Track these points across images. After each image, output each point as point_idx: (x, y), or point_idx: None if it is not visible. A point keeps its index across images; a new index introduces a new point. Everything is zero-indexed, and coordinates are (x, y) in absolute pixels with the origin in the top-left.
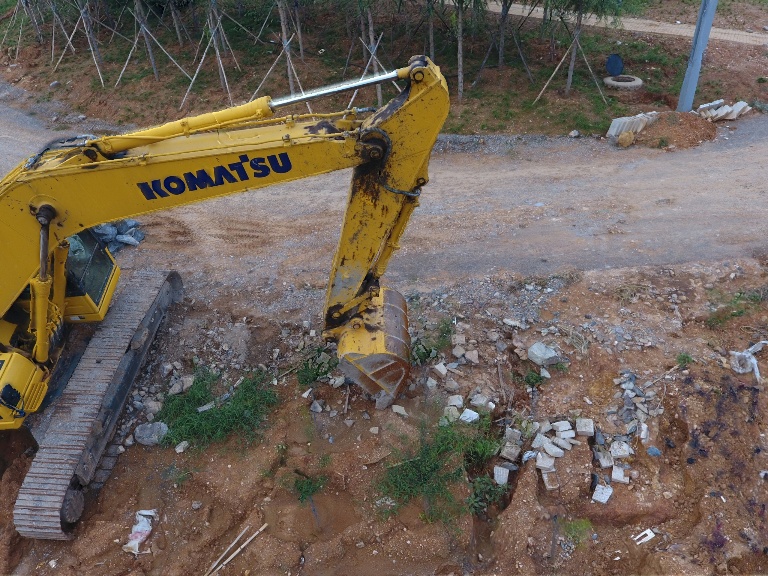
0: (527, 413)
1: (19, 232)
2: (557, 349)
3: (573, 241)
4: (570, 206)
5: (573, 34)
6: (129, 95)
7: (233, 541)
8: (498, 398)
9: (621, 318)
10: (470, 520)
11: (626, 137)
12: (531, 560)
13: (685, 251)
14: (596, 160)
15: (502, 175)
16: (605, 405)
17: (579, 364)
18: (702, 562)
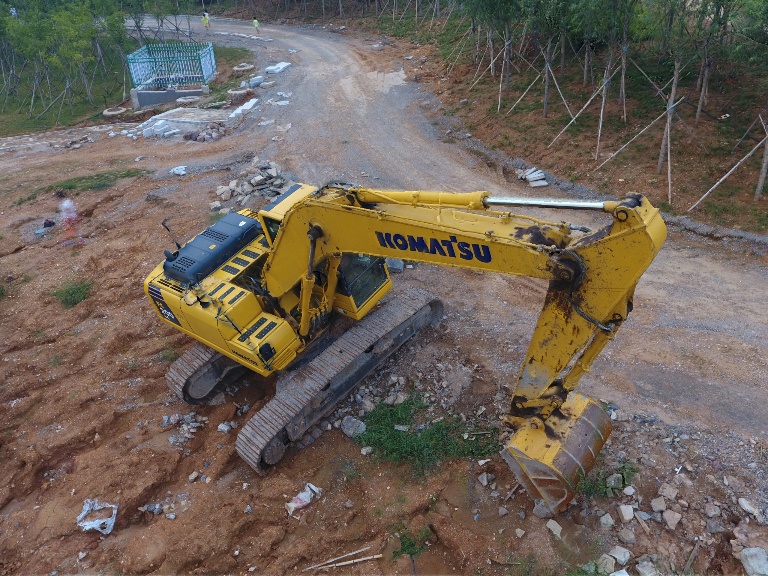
0: None
1: (302, 238)
2: None
3: None
4: None
5: None
6: (514, 124)
7: (354, 551)
8: None
9: None
10: None
11: None
12: None
13: None
14: None
15: None
16: None
17: None
18: None
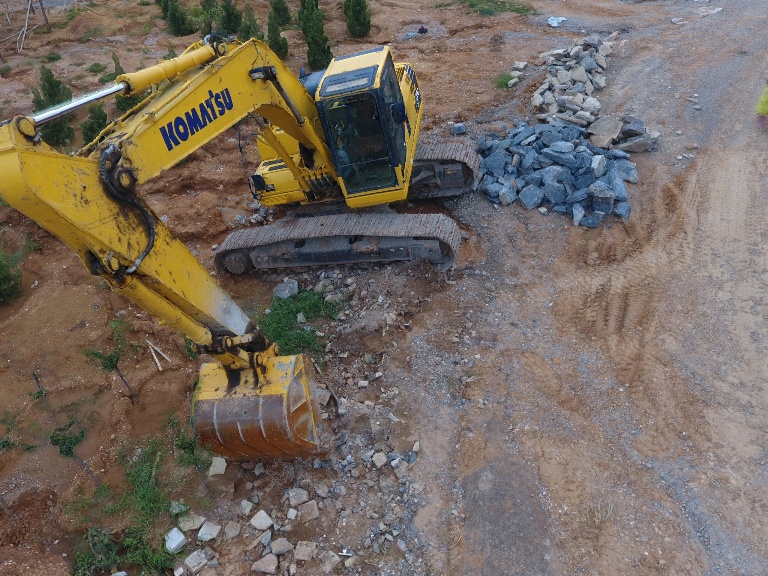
0: None
1: None
2: None
3: None
4: None
5: None
6: None
7: None
8: None
9: None
10: None
11: None
12: (6, 575)
13: None
14: None
15: None
16: None
17: None
18: None
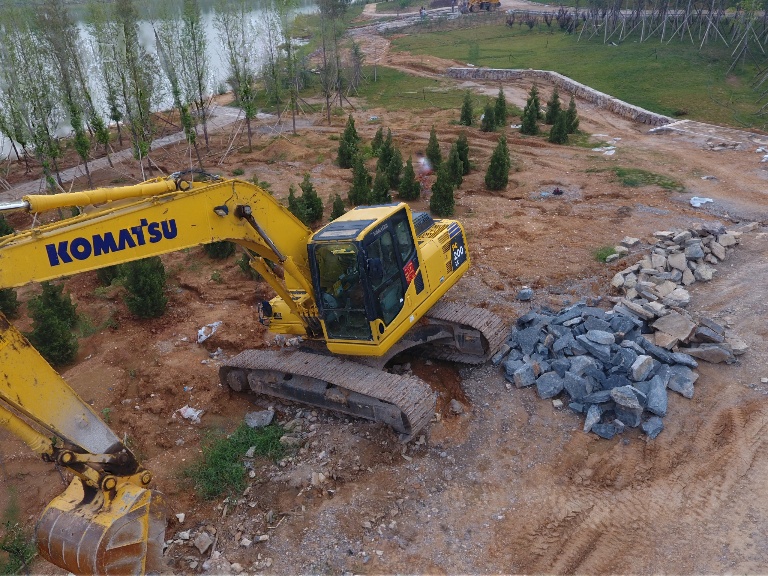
0: None
1: None
2: None
3: None
4: None
5: None
6: None
7: None
8: None
9: None
10: None
11: None
12: None
13: None
14: None
15: None
16: None
17: None
18: None
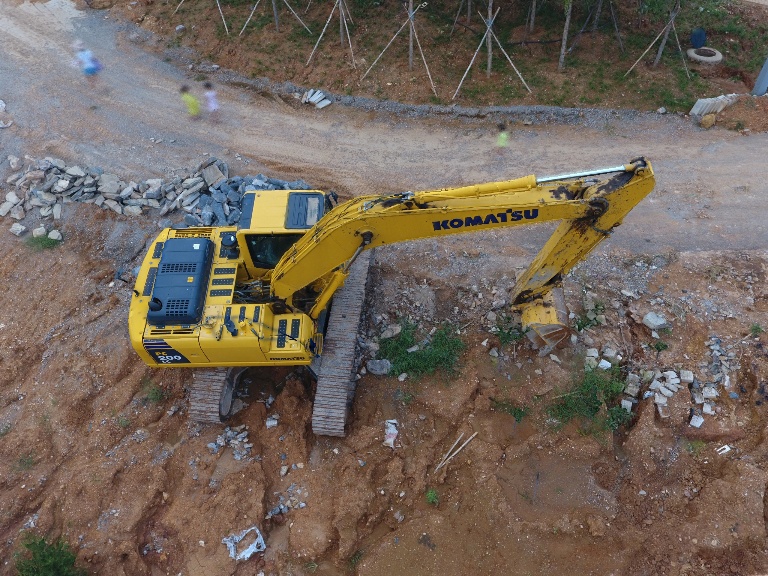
0: (643, 363)
1: (340, 245)
2: (663, 317)
3: (669, 223)
4: (664, 189)
5: (670, 16)
6: (256, 46)
7: (455, 442)
8: (623, 352)
9: (709, 294)
10: (612, 435)
11: (709, 120)
12: (654, 462)
13: (758, 238)
14: (682, 140)
15: (603, 152)
16: (699, 360)
17: (679, 329)
18: (764, 467)
